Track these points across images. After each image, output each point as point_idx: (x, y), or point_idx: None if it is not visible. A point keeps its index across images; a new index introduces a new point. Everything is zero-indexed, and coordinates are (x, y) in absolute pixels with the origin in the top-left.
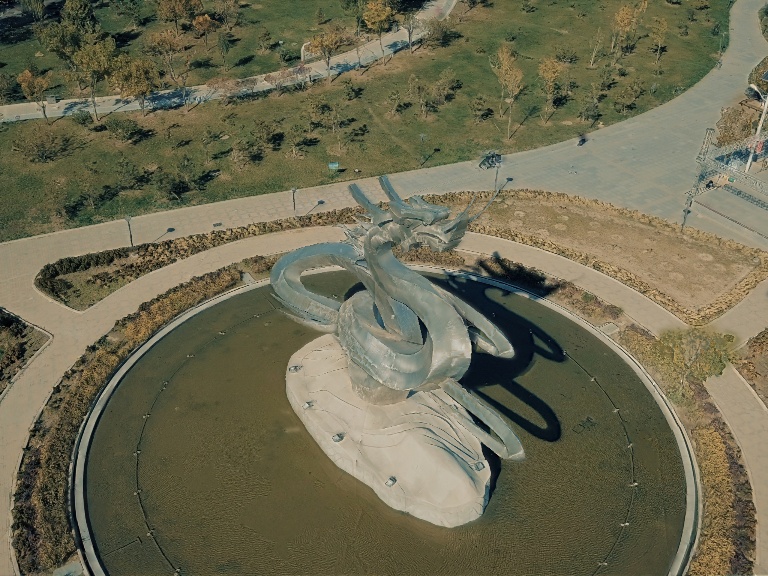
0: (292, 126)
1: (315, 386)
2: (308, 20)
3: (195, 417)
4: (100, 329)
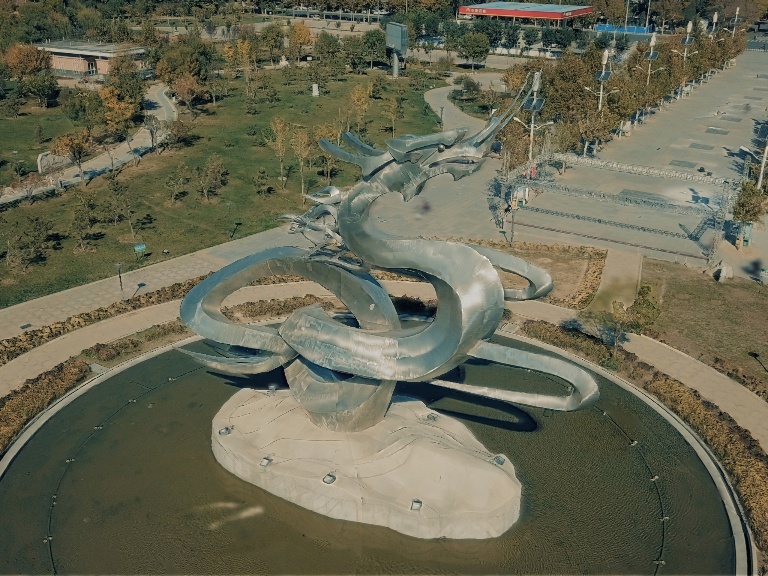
0: (77, 216)
1: (262, 440)
2: (25, 141)
3: (117, 522)
4: None
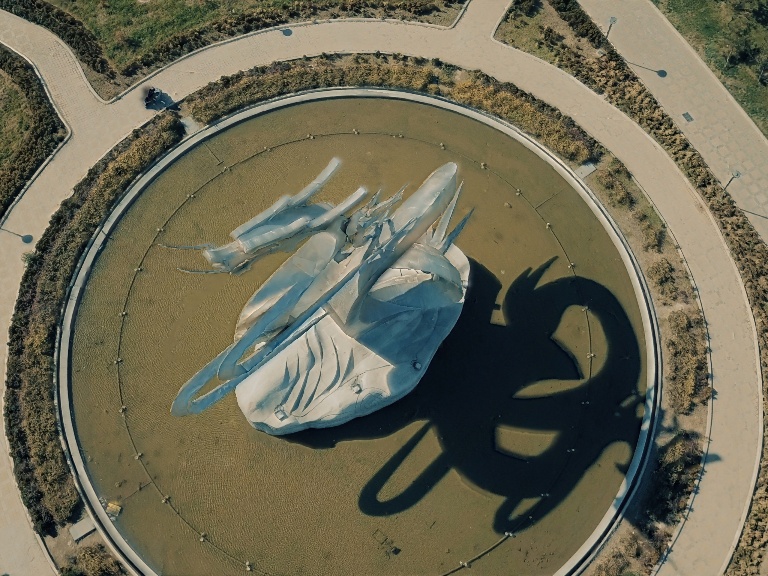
0: None
1: None
2: None
3: (360, 170)
4: (469, 61)
